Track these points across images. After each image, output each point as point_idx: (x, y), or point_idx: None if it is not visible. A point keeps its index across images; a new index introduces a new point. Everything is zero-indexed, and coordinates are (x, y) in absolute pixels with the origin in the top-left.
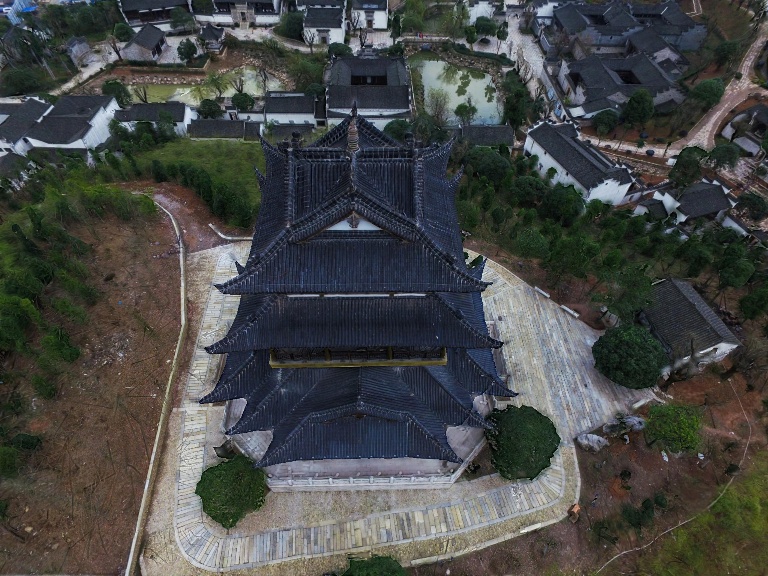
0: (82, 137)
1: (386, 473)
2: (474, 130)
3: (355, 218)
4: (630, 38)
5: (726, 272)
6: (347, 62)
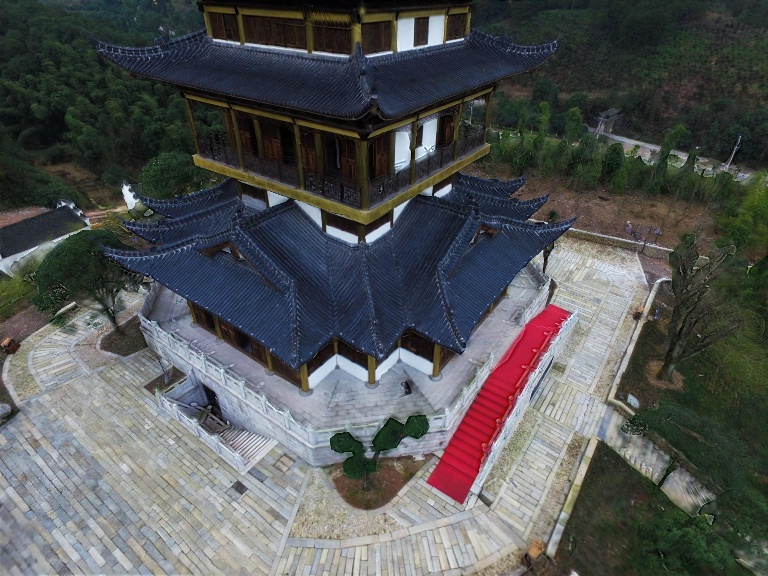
0: None
1: None
2: None
3: None
4: None
5: None
6: None
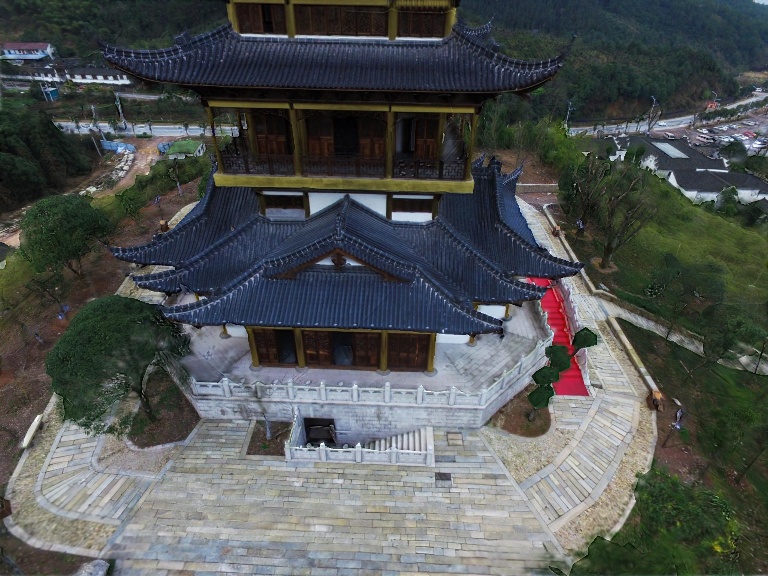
0: (700, 191)
1: None
2: None
3: None
4: None
5: None
6: None
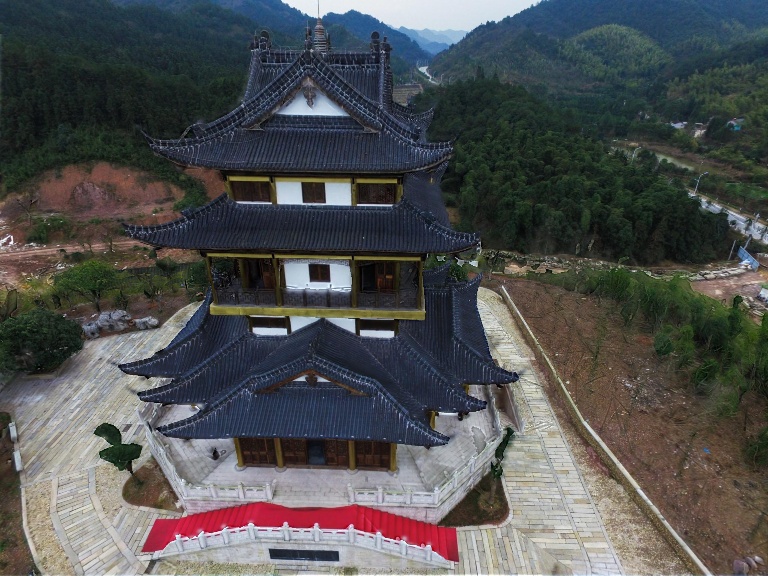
0: None
1: None
2: None
3: None
4: None
5: None
6: None
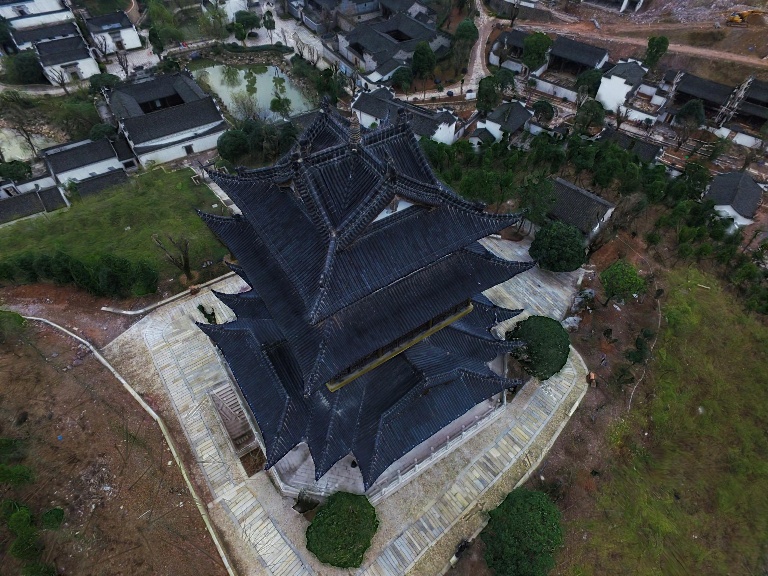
0: None
1: (453, 434)
2: (302, 119)
3: (396, 201)
4: (381, 2)
5: (578, 159)
6: (125, 91)
